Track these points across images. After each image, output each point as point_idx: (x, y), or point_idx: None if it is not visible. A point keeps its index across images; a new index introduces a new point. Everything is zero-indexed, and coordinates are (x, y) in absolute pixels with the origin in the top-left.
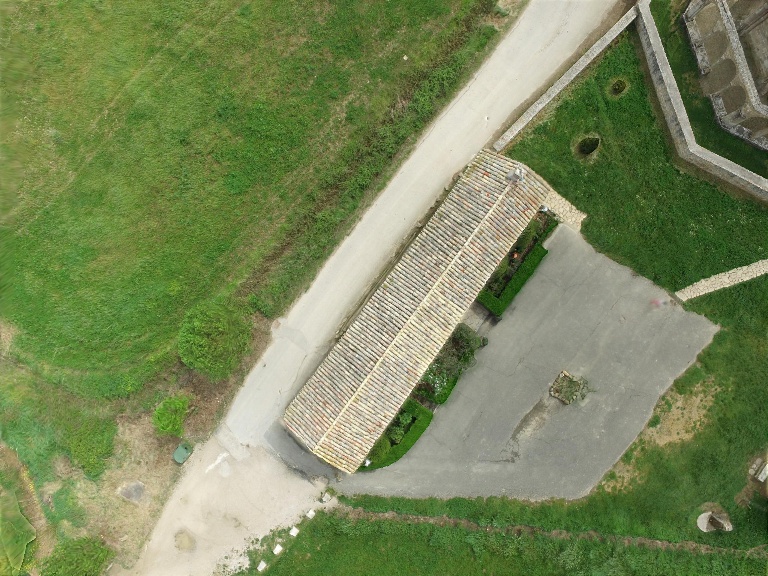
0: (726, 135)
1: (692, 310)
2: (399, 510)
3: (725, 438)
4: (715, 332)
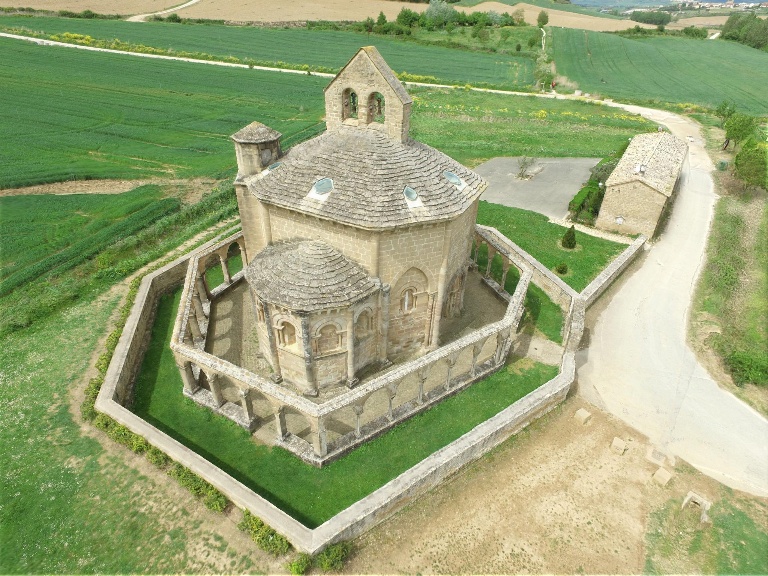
0: None
1: None
2: (590, 154)
3: None
4: None
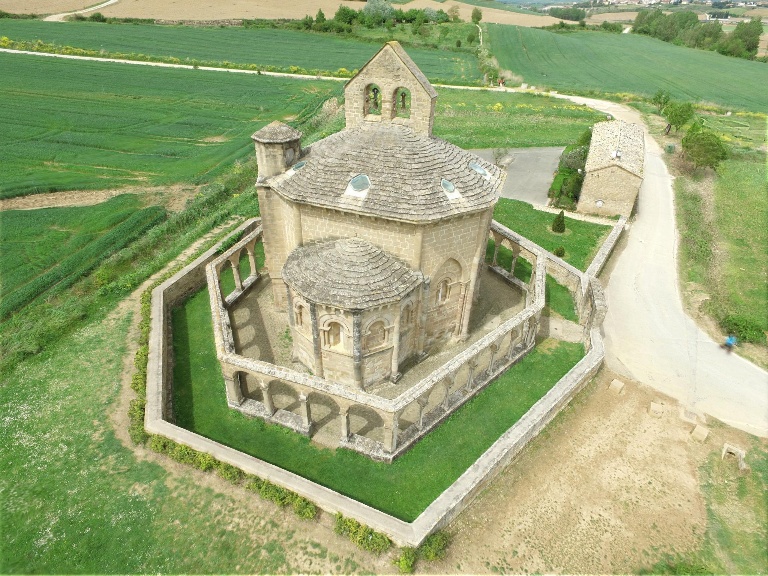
0: None
1: None
2: (553, 143)
3: None
4: None
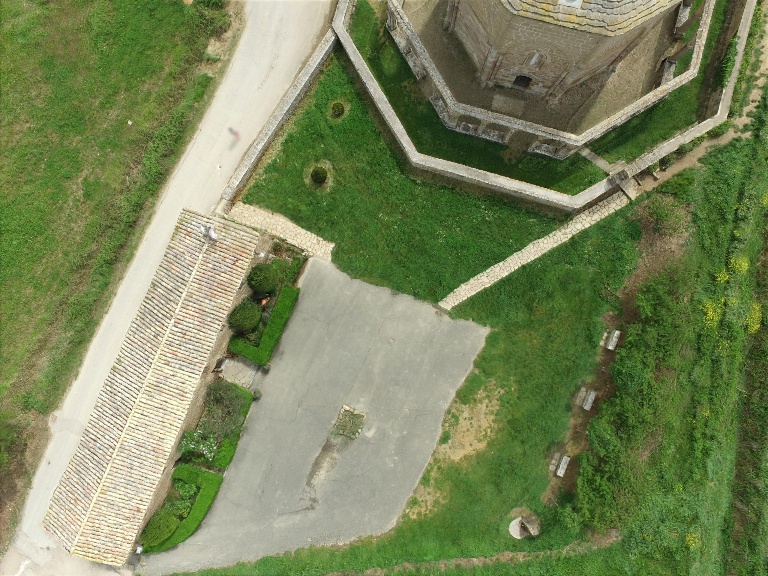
0: (455, 135)
1: (459, 317)
2: None
3: (517, 440)
4: (486, 334)
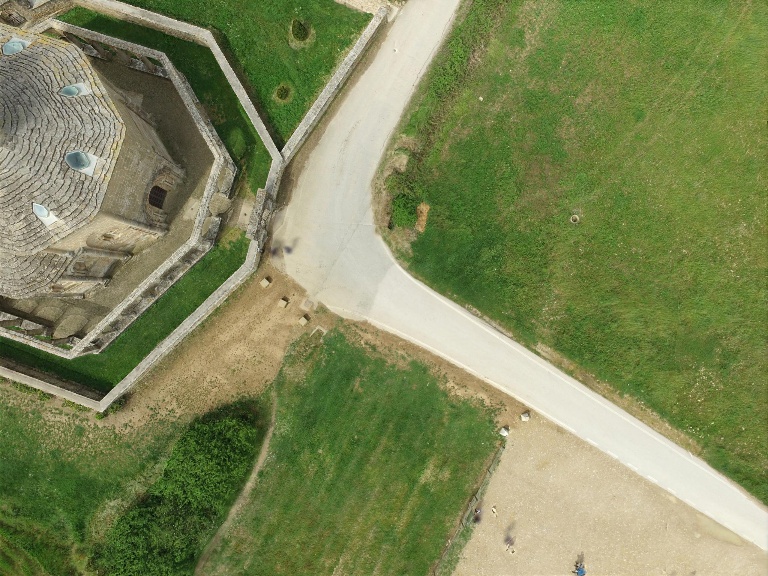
0: None
1: None
2: None
3: None
4: None
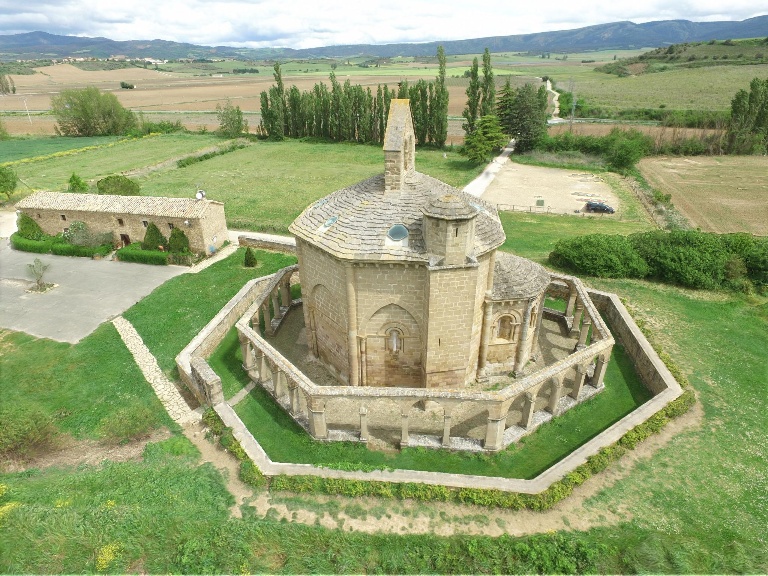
0: None
1: None
2: None
3: None
4: (70, 342)
